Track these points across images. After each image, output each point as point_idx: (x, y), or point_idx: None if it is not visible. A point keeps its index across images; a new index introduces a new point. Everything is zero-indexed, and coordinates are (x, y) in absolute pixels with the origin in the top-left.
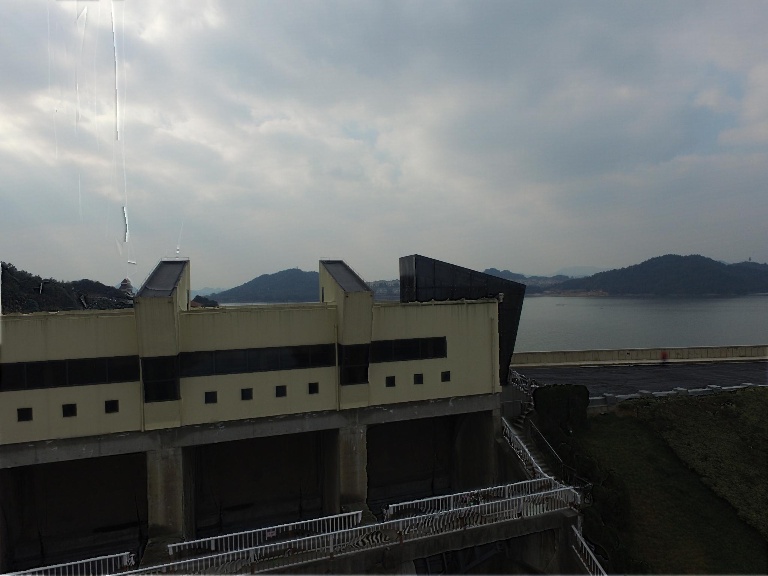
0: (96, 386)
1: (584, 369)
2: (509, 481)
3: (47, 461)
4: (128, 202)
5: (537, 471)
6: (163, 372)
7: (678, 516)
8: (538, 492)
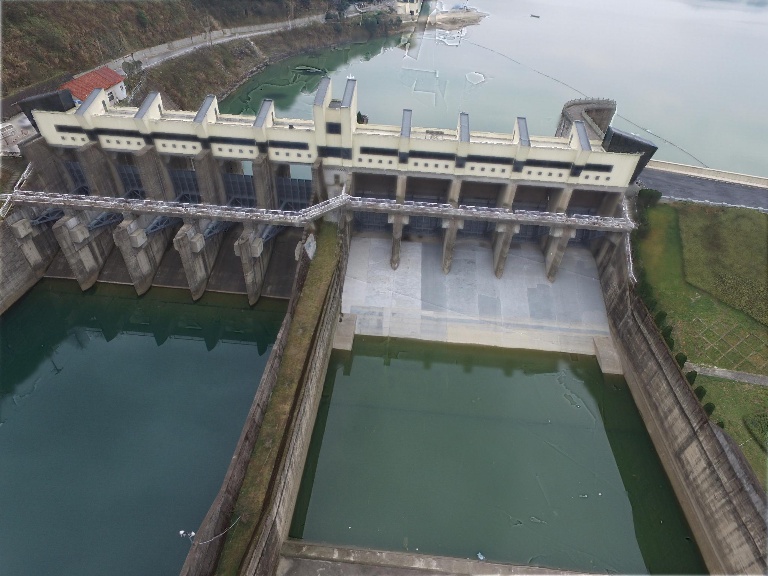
0: (501, 165)
1: (686, 178)
2: (617, 217)
3: (485, 181)
4: None
5: (627, 216)
6: (520, 164)
7: (664, 239)
8: (622, 222)
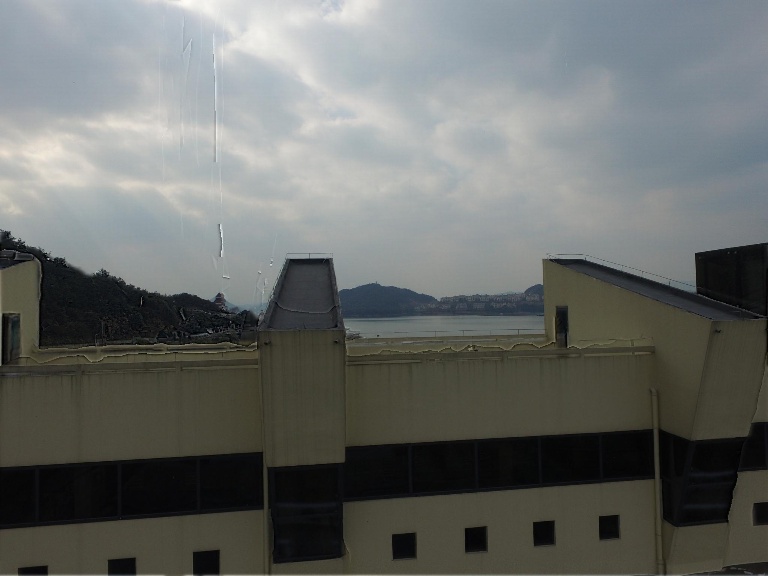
0: (176, 519)
1: None
2: None
3: None
4: (223, 220)
5: None
6: (312, 494)
7: None
8: None
